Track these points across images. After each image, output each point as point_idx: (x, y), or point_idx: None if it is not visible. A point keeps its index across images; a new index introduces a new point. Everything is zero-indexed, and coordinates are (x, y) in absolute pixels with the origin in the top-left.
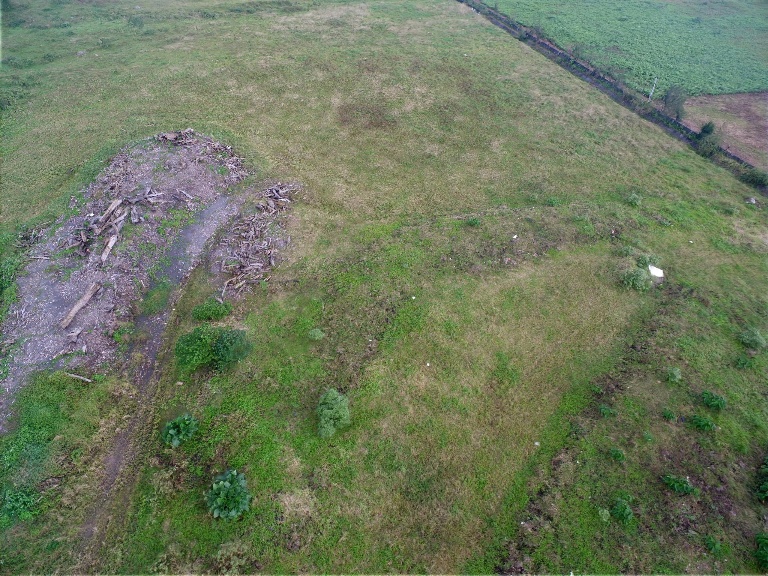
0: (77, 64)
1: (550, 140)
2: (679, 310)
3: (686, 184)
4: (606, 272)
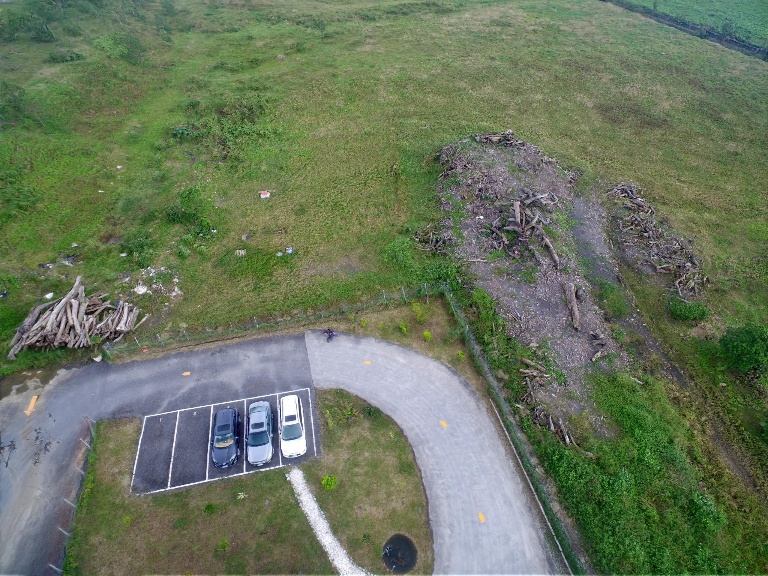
0: (286, 68)
1: None
2: None
3: None
4: None
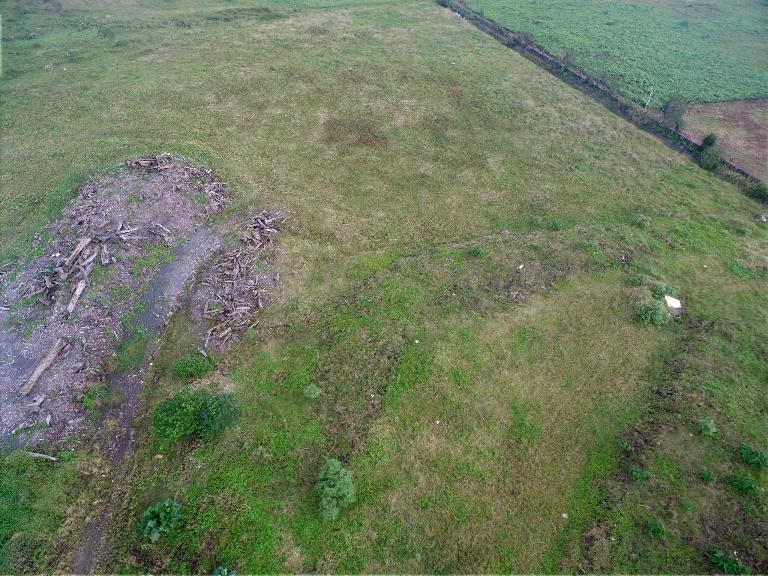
0: (43, 79)
1: (548, 155)
2: (702, 347)
3: (693, 201)
4: (620, 304)
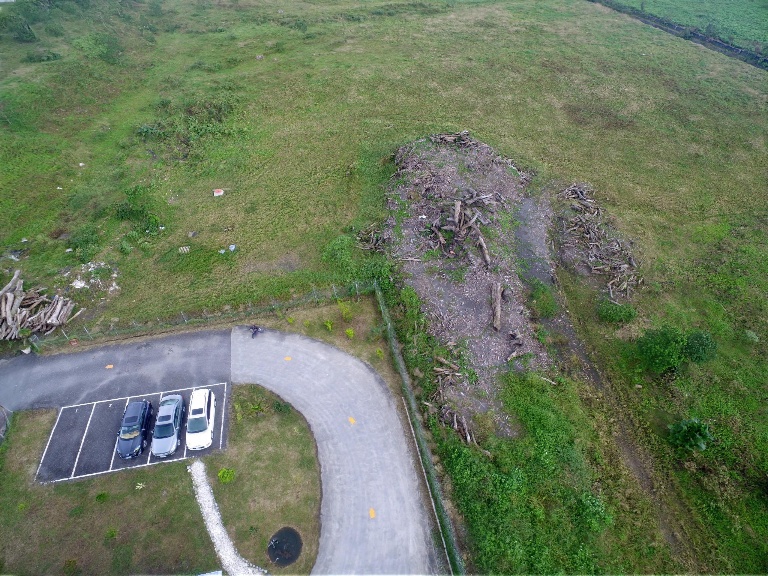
0: (263, 68)
1: None
2: None
3: None
4: None
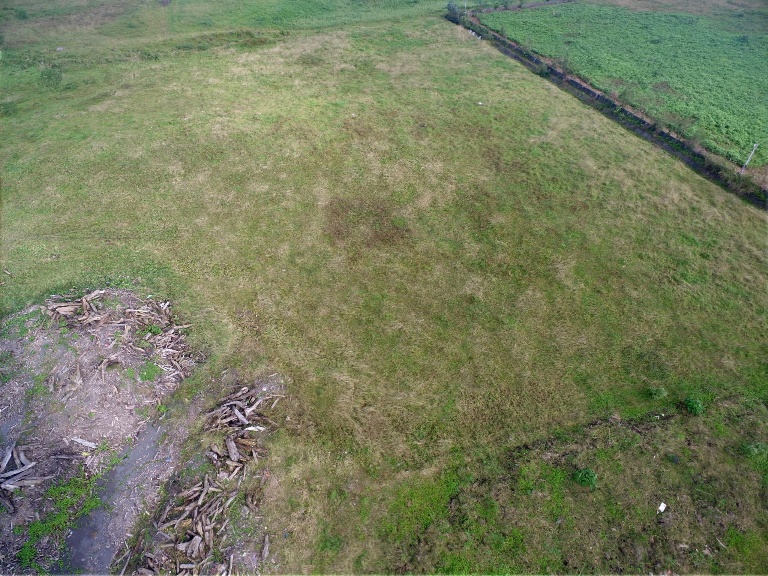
0: None
1: (637, 254)
2: None
3: None
4: None
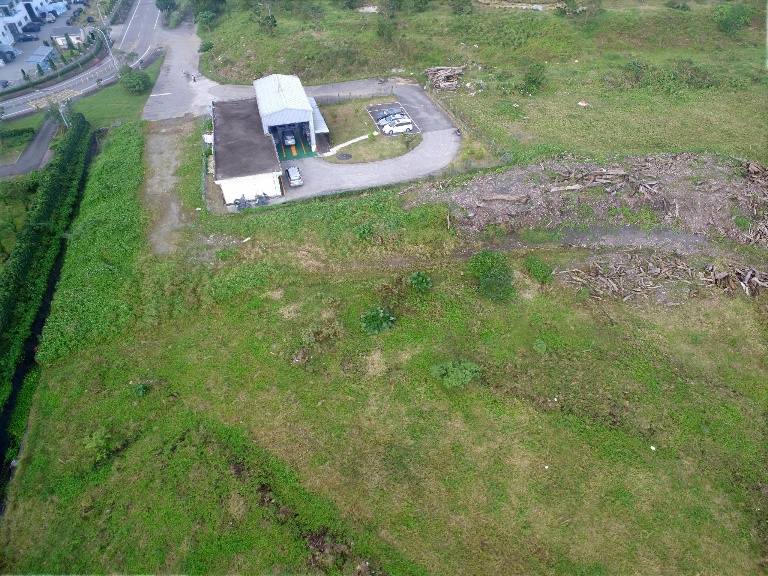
0: None
1: None
2: None
3: None
4: None
